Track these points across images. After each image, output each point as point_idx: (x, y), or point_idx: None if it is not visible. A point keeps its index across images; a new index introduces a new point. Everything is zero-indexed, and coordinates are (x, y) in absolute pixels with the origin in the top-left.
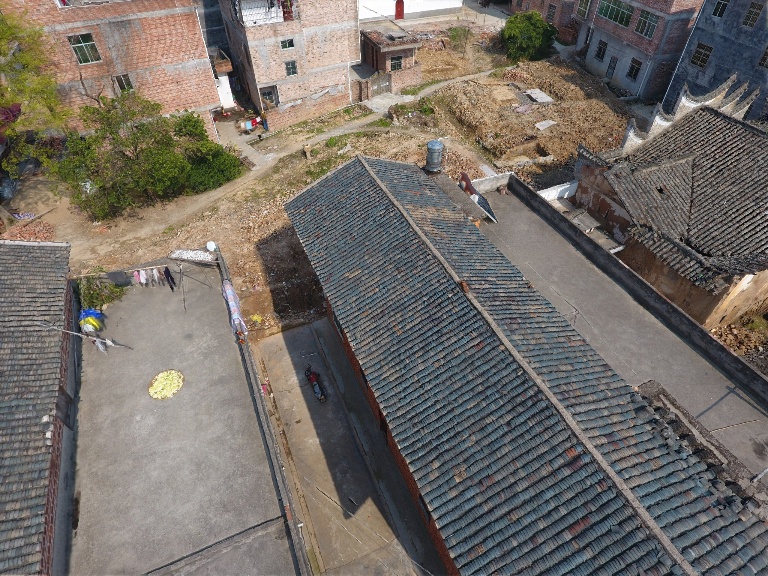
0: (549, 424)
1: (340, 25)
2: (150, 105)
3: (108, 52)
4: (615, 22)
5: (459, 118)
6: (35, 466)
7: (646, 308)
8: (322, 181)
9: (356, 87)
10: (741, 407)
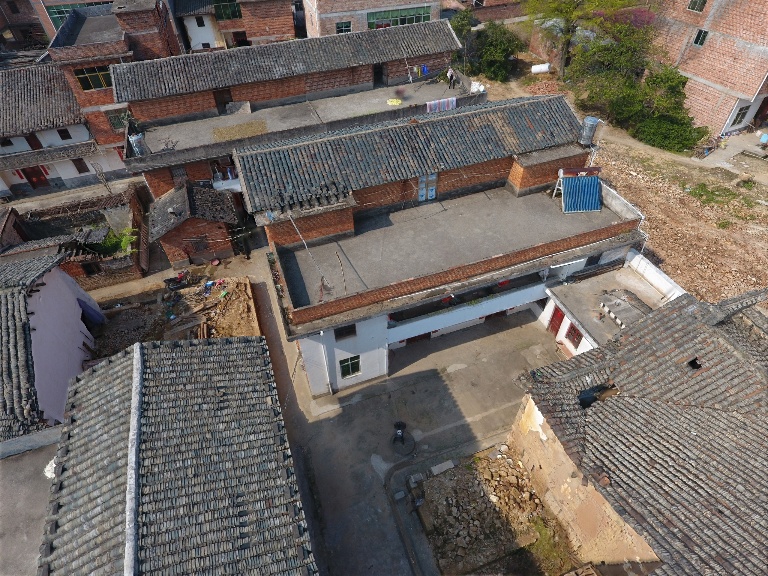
0: None
1: None
2: (644, 43)
3: (711, 8)
4: None
5: None
6: (342, 64)
7: None
8: None
9: None
10: None
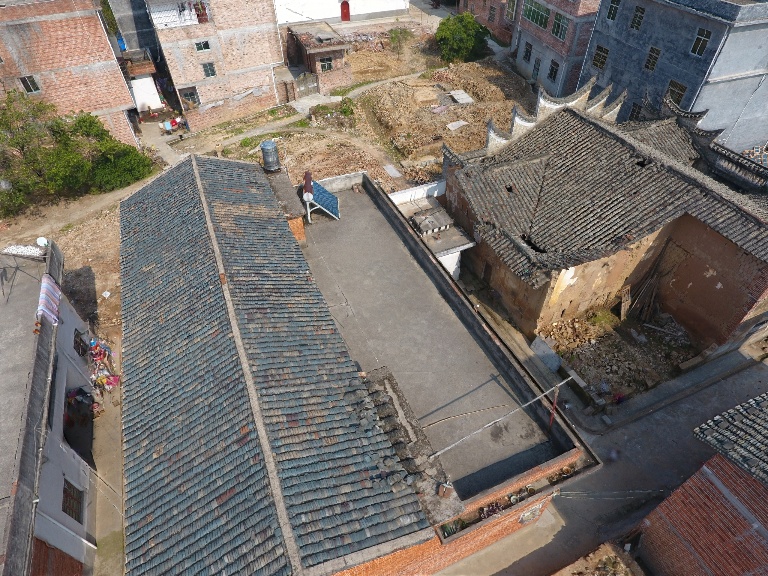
0: (237, 404)
1: (258, 27)
2: (36, 106)
3: (9, 54)
4: (536, 24)
5: (379, 119)
6: None
7: (447, 301)
8: (156, 179)
9: (282, 88)
10: (496, 393)
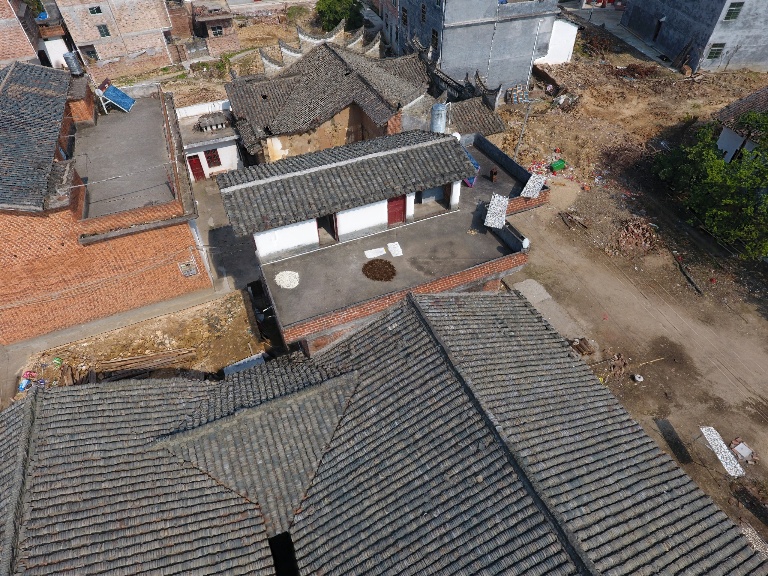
0: None
1: None
2: None
3: None
4: None
5: None
6: None
7: None
8: None
9: (174, 50)
10: (162, 189)
